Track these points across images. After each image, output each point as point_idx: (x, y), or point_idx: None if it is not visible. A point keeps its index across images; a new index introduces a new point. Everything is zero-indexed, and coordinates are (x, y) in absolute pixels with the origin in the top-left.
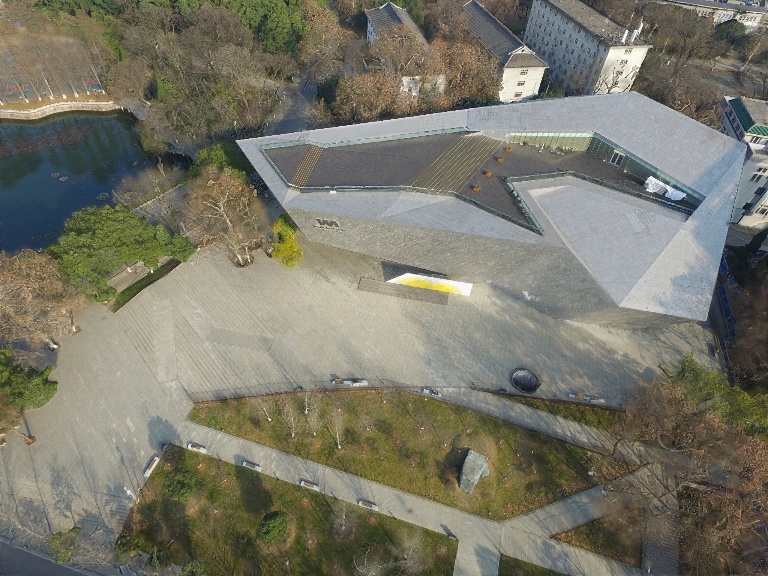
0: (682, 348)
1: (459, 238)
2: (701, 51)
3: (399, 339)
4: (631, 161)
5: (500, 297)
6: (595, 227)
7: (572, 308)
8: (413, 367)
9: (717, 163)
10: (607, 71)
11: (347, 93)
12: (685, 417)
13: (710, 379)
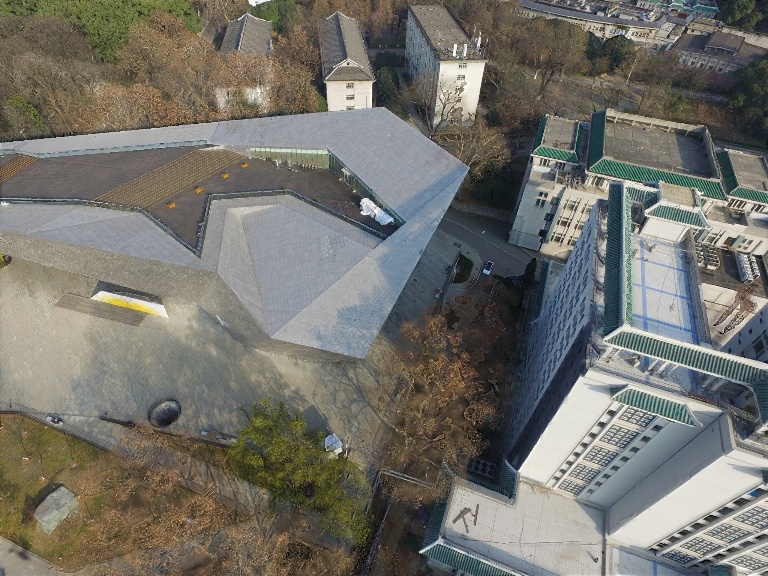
0: (366, 386)
1: (114, 257)
2: (583, 68)
3: (62, 360)
4: (356, 181)
5: (201, 320)
6: (284, 250)
7: (248, 336)
8: (55, 391)
9: (431, 186)
10: (444, 86)
11: (99, 103)
12: (123, 472)
13: (255, 427)
